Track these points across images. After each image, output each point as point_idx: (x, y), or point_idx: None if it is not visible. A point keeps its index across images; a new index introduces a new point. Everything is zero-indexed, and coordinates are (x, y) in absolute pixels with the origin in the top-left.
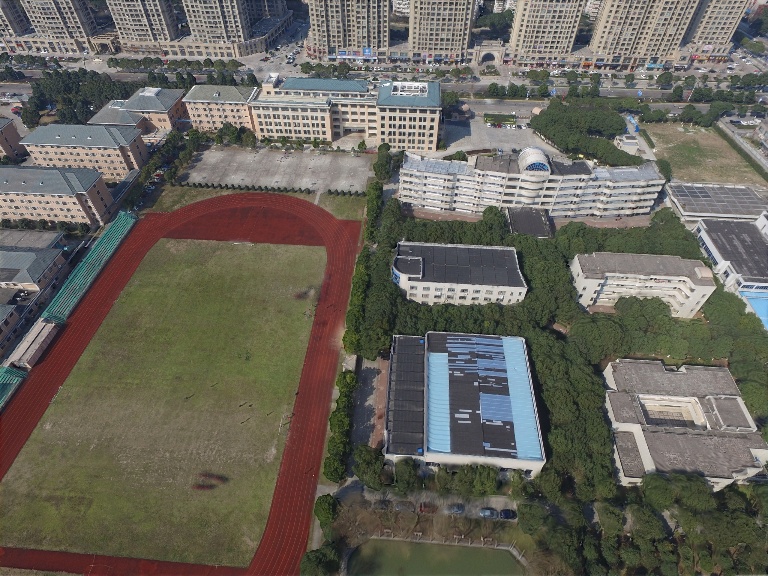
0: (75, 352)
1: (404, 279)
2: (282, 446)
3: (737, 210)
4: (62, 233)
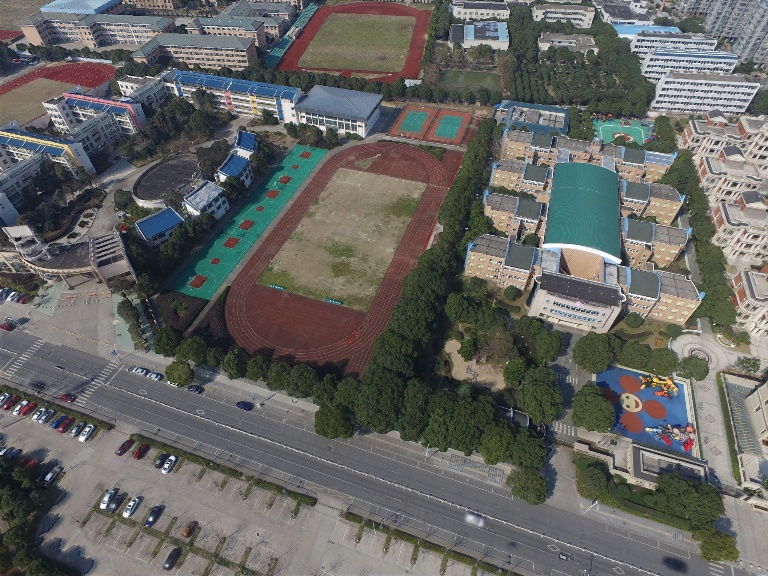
0: (311, 37)
1: (455, 9)
2: (406, 55)
3: None
4: (290, 3)
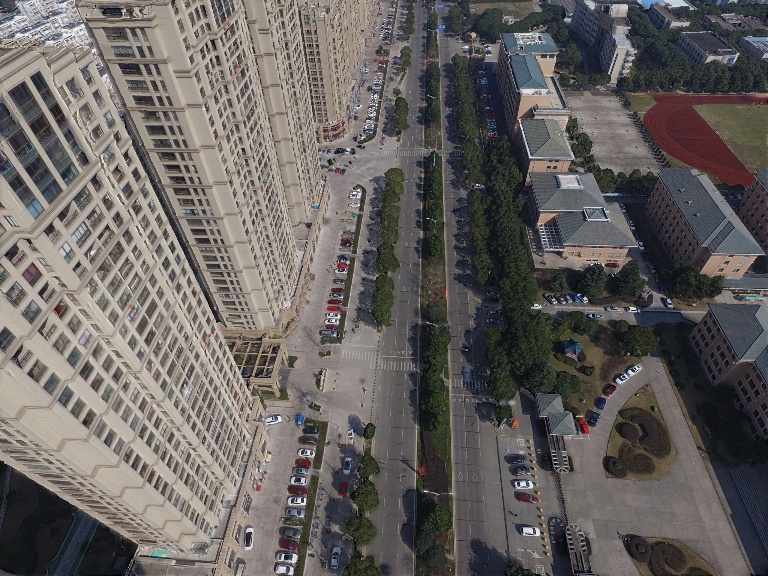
0: None
1: None
2: None
3: (574, 5)
4: None
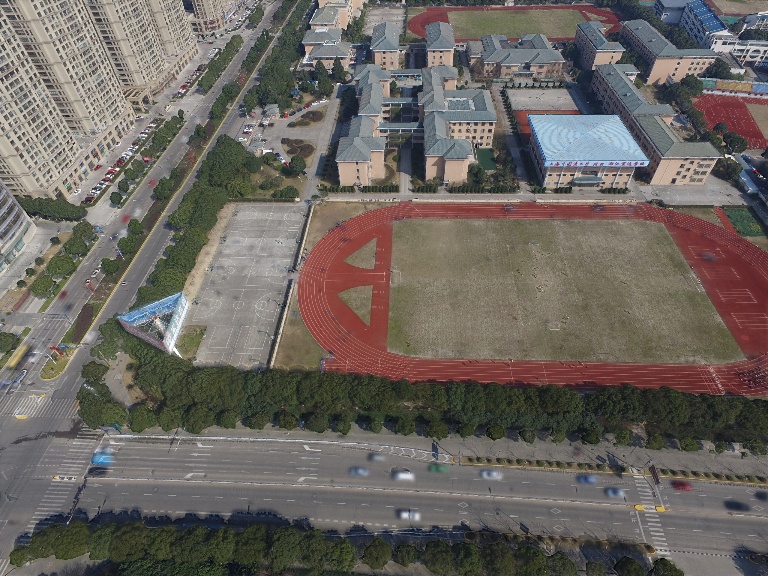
0: None
1: None
2: None
3: None
4: None
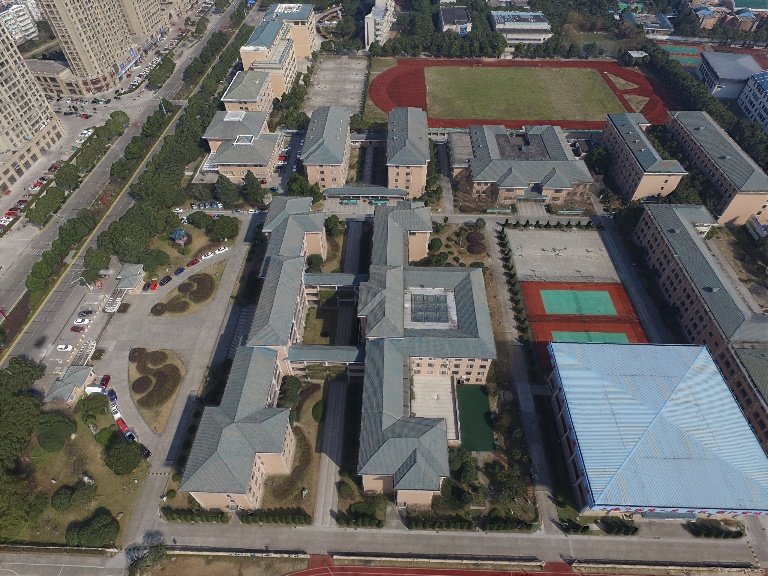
0: (533, 122)
1: None
2: None
3: None
4: None
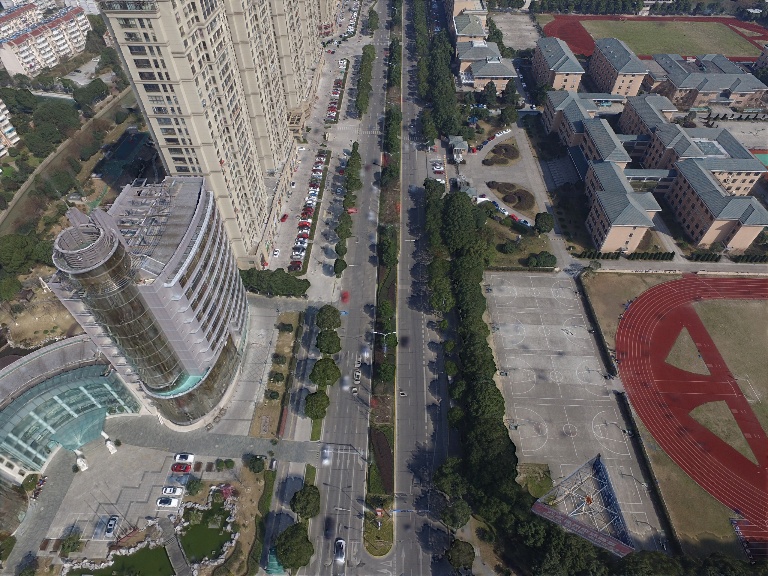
0: None
1: None
2: None
3: None
4: None
